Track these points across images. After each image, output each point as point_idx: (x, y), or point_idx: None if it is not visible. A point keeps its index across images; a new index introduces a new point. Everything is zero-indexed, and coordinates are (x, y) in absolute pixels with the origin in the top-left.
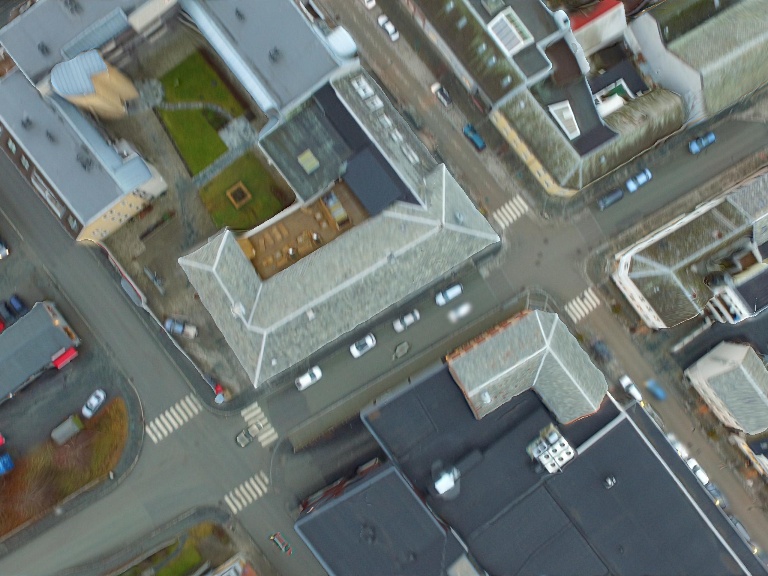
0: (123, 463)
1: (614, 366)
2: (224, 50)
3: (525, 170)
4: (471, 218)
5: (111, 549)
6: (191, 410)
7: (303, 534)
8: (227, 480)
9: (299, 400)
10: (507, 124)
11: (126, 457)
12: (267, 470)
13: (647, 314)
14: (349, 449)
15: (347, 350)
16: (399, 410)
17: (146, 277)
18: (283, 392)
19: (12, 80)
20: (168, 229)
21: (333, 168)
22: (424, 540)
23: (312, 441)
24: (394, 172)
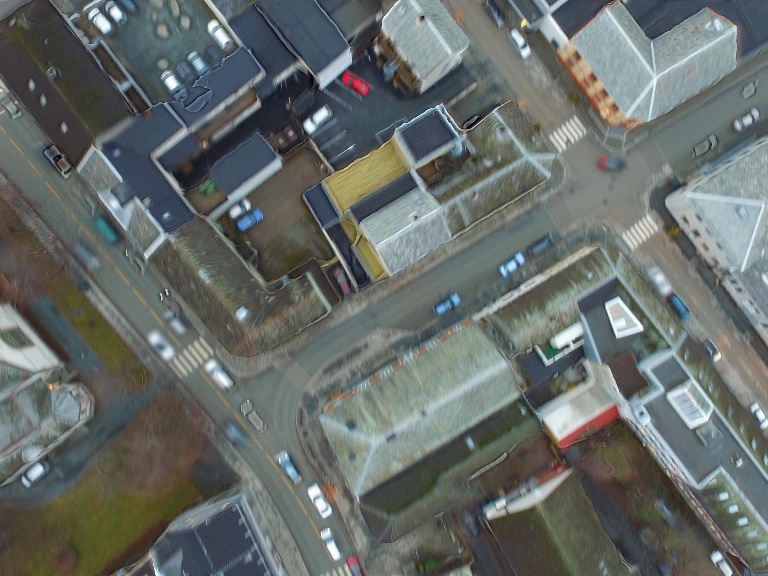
0: None
1: (535, 69)
2: None
3: None
4: (724, 214)
5: None
6: None
7: None
8: None
9: None
10: None
11: None
12: None
13: None
14: None
15: None
16: None
17: None
18: None
19: None
20: None
21: None
22: None
23: None
24: None
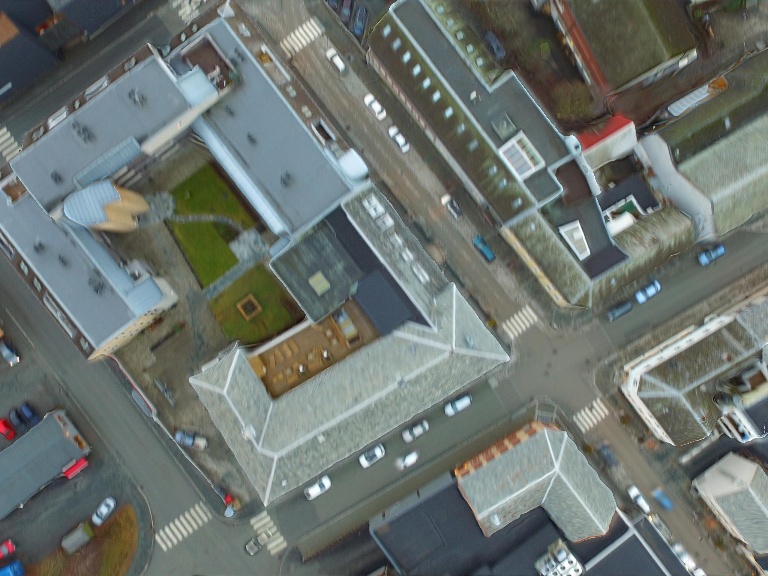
0: (133, 571)
1: (622, 476)
2: (236, 173)
3: (534, 281)
4: (481, 339)
5: None
6: (201, 518)
7: None
8: None
9: (308, 509)
10: (517, 241)
11: (136, 565)
12: None
13: (656, 428)
14: (358, 557)
15: (356, 460)
16: (408, 524)
17: (156, 388)
18: (292, 501)
19: (25, 204)
20: (178, 340)
21: (344, 289)
22: None
23: (321, 550)
24: (405, 294)
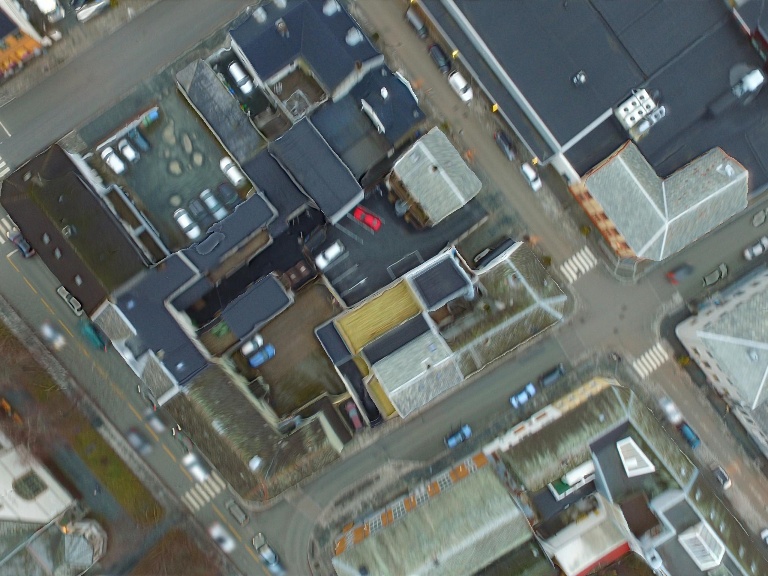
0: None
1: (546, 201)
2: None
3: None
4: (735, 355)
5: None
6: None
7: None
8: None
9: None
10: (681, 451)
11: None
12: None
13: None
14: None
15: None
16: None
17: None
18: None
19: None
20: None
21: None
22: None
23: None
24: None
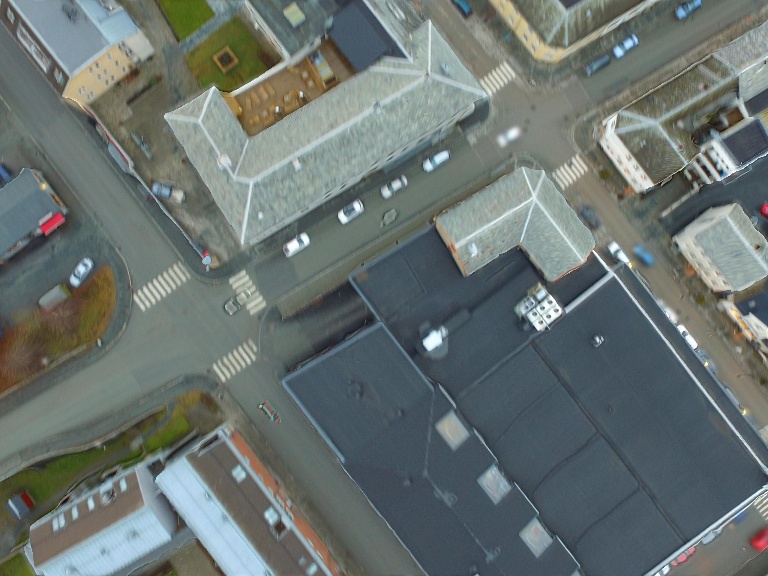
0: (111, 330)
1: (602, 233)
2: None
3: (512, 36)
4: (457, 72)
5: (99, 416)
6: (179, 278)
7: (291, 389)
8: (215, 348)
9: (287, 268)
10: None
11: (114, 325)
12: (255, 338)
13: (634, 176)
14: (337, 317)
15: (335, 217)
16: (387, 271)
17: (133, 142)
18: (271, 260)
19: None
20: (155, 94)
21: (319, 22)
22: (412, 396)
23: (300, 308)
24: (380, 25)
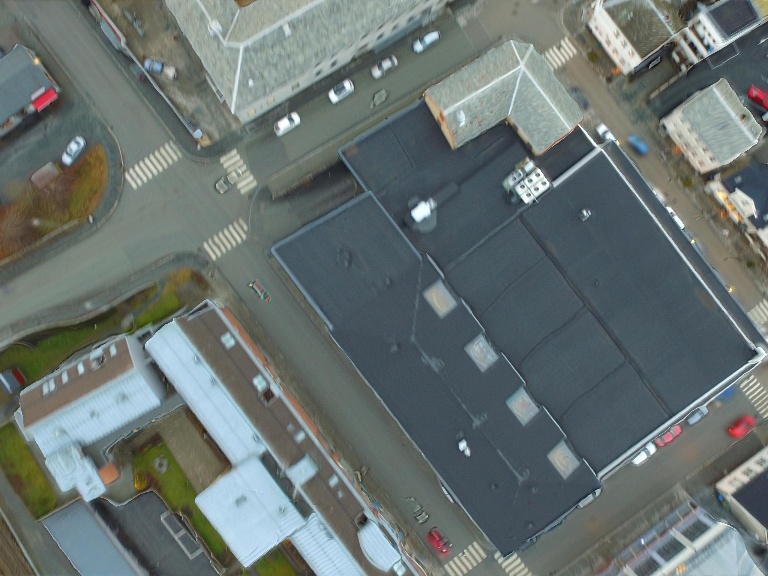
0: (102, 208)
1: (591, 115)
2: None
3: None
4: None
5: (90, 292)
6: (170, 157)
7: (280, 257)
8: (206, 227)
9: (278, 147)
10: None
11: (105, 202)
12: (246, 217)
13: (622, 56)
14: (328, 198)
15: (325, 96)
16: (376, 146)
17: (126, 19)
18: (262, 139)
19: None
20: None
21: None
22: (400, 265)
23: (291, 187)
24: None
